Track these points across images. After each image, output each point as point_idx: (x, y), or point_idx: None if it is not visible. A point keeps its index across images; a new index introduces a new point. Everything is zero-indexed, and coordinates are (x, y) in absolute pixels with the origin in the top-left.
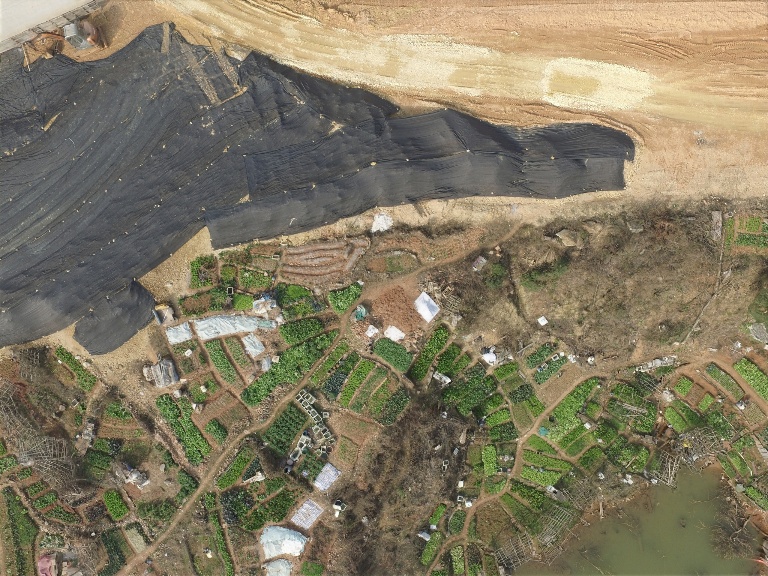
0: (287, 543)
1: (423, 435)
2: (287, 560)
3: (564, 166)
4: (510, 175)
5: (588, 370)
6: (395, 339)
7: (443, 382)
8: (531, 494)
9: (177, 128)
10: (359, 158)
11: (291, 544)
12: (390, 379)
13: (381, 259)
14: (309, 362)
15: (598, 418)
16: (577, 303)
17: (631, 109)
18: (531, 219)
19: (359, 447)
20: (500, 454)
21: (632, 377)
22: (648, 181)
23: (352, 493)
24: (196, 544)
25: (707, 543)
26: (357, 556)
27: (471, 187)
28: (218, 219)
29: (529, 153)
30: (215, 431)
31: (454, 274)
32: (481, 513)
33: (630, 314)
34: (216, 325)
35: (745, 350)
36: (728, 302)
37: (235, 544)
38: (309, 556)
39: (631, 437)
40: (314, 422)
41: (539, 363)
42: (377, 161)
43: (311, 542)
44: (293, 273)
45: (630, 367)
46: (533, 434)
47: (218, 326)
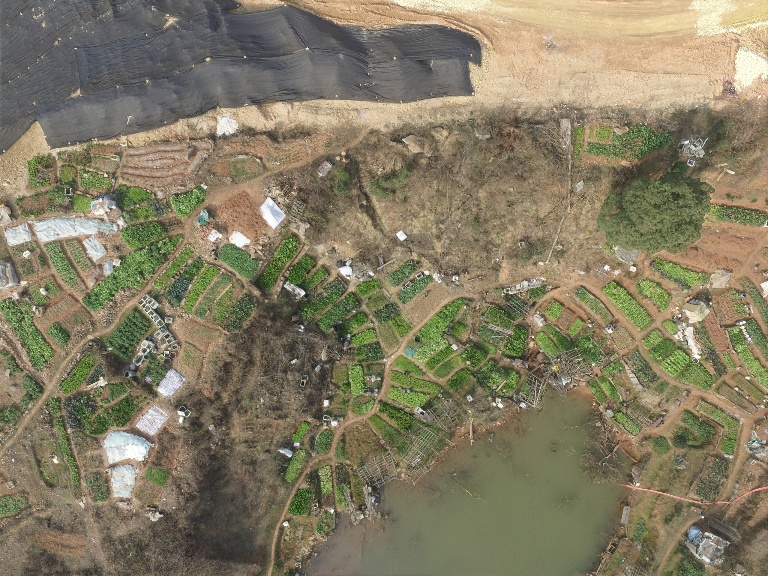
0: (130, 448)
1: (277, 347)
2: (132, 466)
3: (406, 67)
4: (354, 77)
5: (455, 291)
6: (240, 245)
7: (297, 294)
8: (399, 415)
9: (7, 19)
10: (194, 53)
11: (134, 449)
12: (235, 285)
13: (225, 163)
14: (152, 267)
15: (467, 340)
16: (432, 216)
17: (479, 11)
18: (378, 124)
19: (204, 354)
20: (367, 374)
21: (502, 300)
22: (497, 87)
23: (197, 400)
24: (43, 449)
25: (577, 468)
26: (203, 463)
27: (315, 89)
28: (49, 114)
29: (373, 54)
30: (56, 334)
31: (300, 180)
32: (350, 434)
33: (488, 229)
34: (55, 226)
35: (613, 273)
36: (586, 218)
37: (78, 448)
38: (154, 462)
39: (502, 361)
40: (158, 328)
41: (402, 281)
42: (212, 57)
43: (156, 448)
44: (134, 175)
45: (497, 288)
46: (400, 355)
47: (57, 227)
